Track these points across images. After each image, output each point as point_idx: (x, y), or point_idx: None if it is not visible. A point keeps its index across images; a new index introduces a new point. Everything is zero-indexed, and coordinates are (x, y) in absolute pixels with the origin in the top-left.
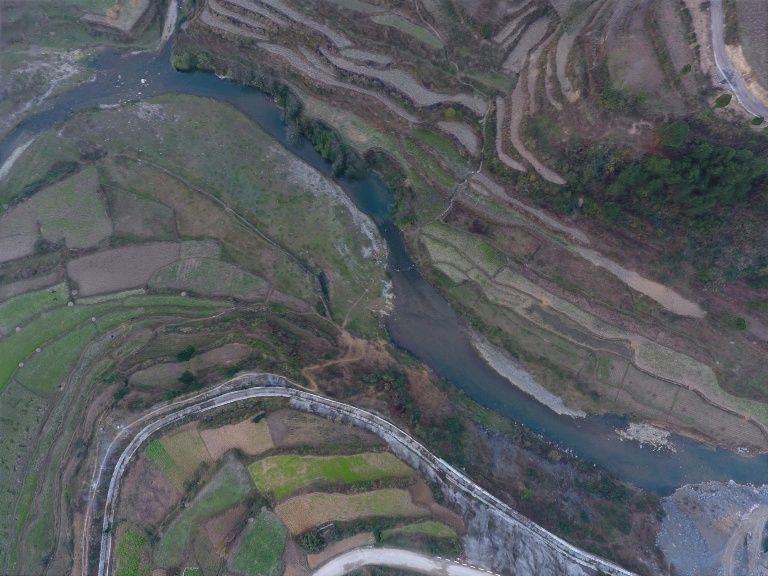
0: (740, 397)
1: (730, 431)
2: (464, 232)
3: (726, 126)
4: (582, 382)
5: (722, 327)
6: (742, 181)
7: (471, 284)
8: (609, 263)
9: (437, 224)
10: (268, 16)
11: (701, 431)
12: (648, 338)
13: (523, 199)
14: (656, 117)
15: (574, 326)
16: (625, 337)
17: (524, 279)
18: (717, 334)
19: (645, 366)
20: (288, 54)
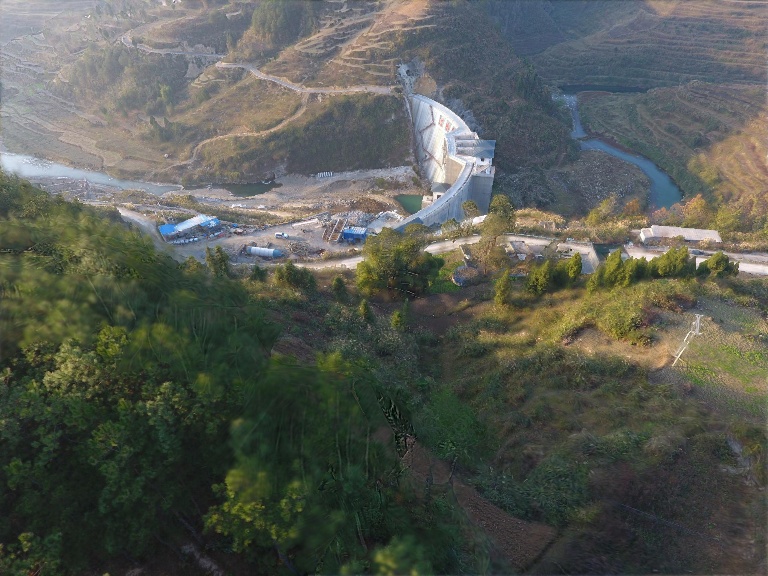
0: (102, 149)
1: (85, 159)
2: (23, 105)
3: (114, 46)
4: (25, 143)
5: None
6: (111, 57)
7: (9, 117)
8: (78, 111)
9: (14, 103)
10: (5, 57)
11: (68, 158)
12: (74, 132)
13: None
14: None
15: (42, 128)
16: None
17: (35, 116)
18: (110, 131)
19: None
20: (5, 67)
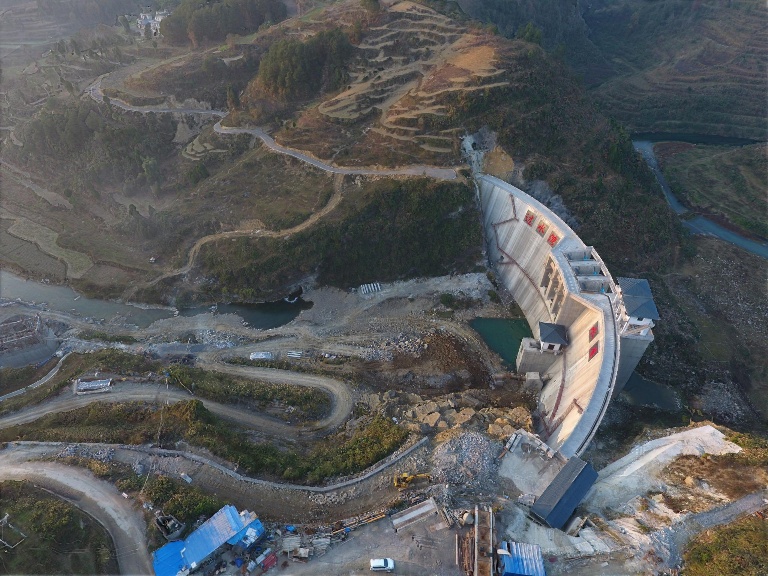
0: (65, 248)
1: (41, 266)
2: None
3: (80, 101)
4: None
5: (80, 213)
6: (76, 118)
7: None
8: (35, 186)
9: None
10: None
11: (19, 264)
12: (29, 219)
13: (7, 160)
14: (59, 106)
15: None
16: (15, 218)
17: None
18: (76, 218)
19: (13, 231)
20: None
